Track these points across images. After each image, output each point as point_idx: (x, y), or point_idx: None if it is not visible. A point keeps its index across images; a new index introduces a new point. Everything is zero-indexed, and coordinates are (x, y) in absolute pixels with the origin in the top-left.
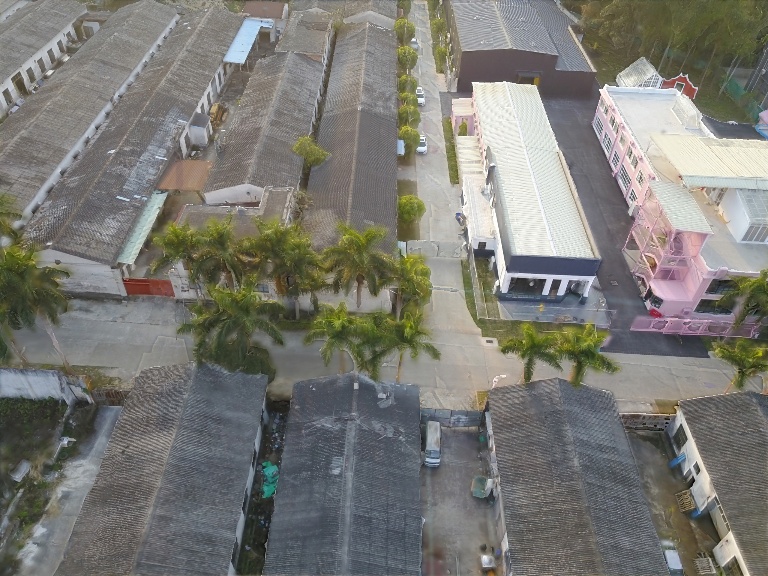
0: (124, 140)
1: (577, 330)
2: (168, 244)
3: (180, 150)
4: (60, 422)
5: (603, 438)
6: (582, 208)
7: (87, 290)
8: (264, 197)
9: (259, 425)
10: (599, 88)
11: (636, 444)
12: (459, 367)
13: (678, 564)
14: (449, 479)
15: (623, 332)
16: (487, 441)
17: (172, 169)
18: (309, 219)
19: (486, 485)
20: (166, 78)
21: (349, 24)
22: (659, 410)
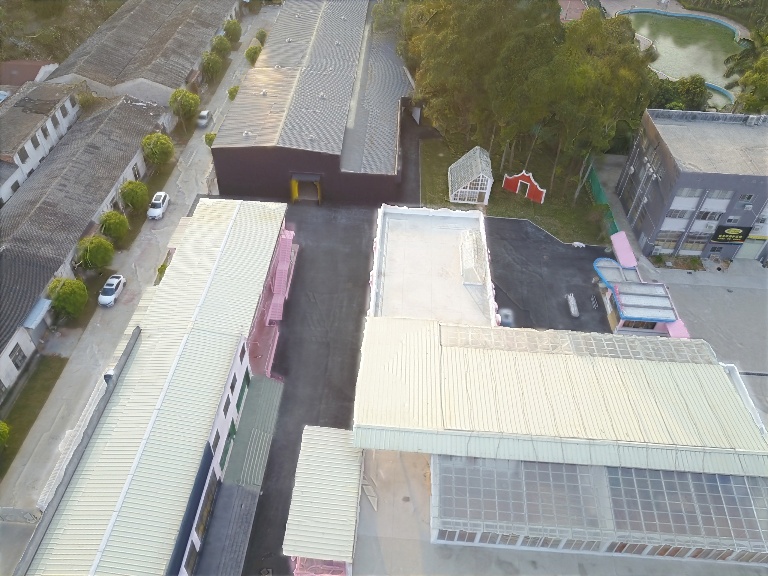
0: None
1: None
2: None
3: None
4: None
5: None
6: (198, 470)
7: None
8: None
9: None
10: (417, 187)
11: None
12: None
13: None
14: None
15: None
16: None
17: None
18: None
19: None
20: None
21: (99, 99)
22: None
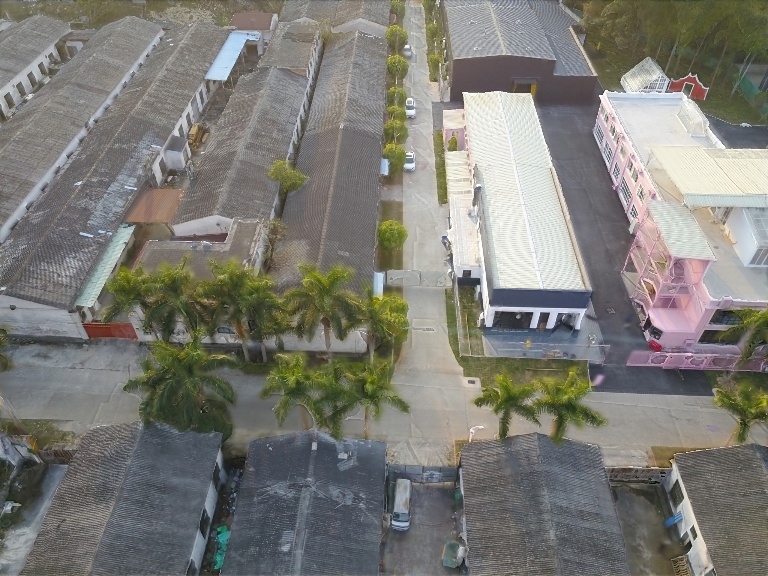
0: (92, 170)
1: (568, 367)
2: (118, 291)
3: (153, 178)
4: (5, 485)
5: (585, 503)
6: (573, 232)
7: (47, 334)
8: (232, 230)
9: (213, 488)
10: (602, 92)
11: (629, 499)
12: (437, 412)
13: None
14: (419, 544)
15: (619, 368)
16: (463, 499)
17: (142, 199)
18: (281, 251)
19: (457, 554)
20: (142, 100)
21: (338, 34)
22: (655, 459)
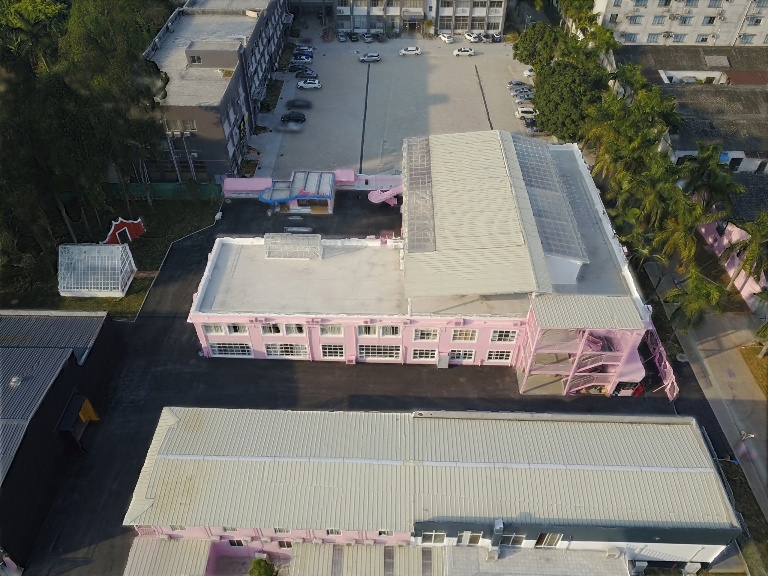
0: None
1: None
2: None
3: None
4: None
5: None
6: (581, 415)
7: None
8: None
9: None
10: None
11: None
12: None
13: None
14: None
15: None
16: None
17: None
18: None
19: None
20: None
21: None
22: None
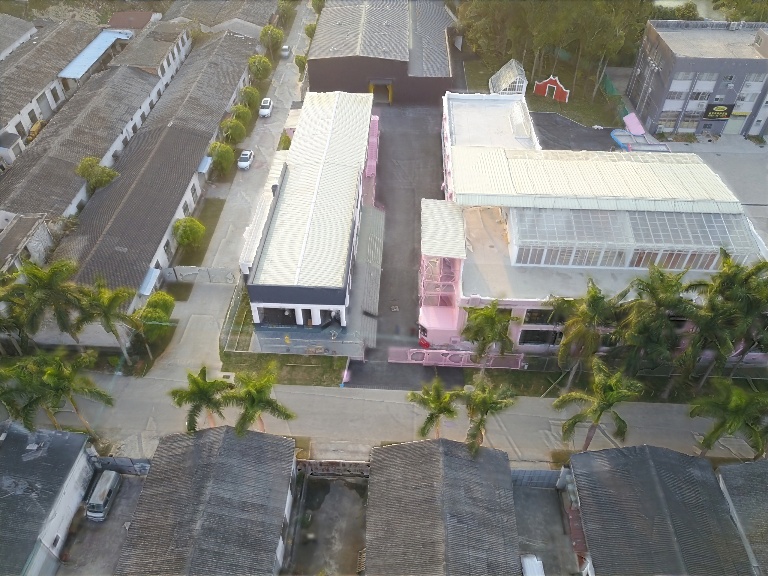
0: None
1: (326, 363)
2: None
3: None
4: None
5: (254, 494)
6: (351, 230)
7: None
8: (10, 225)
9: None
10: (465, 93)
11: (340, 493)
12: None
13: None
14: (112, 535)
15: (380, 364)
16: None
17: None
18: (63, 246)
19: None
20: None
21: (208, 33)
22: None
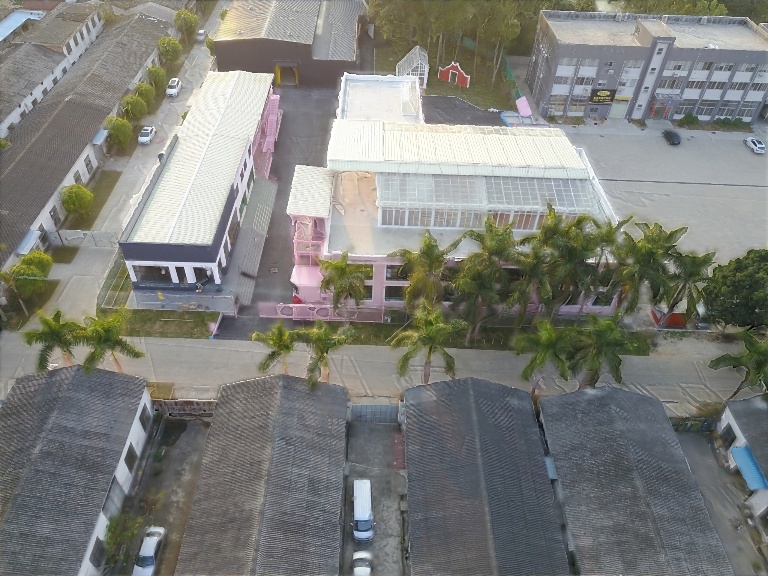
0: None
1: (199, 318)
2: None
3: None
4: None
5: (98, 425)
6: (228, 194)
7: None
8: None
9: None
10: None
11: (195, 431)
12: None
13: (150, 551)
14: None
15: (252, 319)
16: None
17: None
18: None
19: None
20: None
21: (120, 15)
22: None
